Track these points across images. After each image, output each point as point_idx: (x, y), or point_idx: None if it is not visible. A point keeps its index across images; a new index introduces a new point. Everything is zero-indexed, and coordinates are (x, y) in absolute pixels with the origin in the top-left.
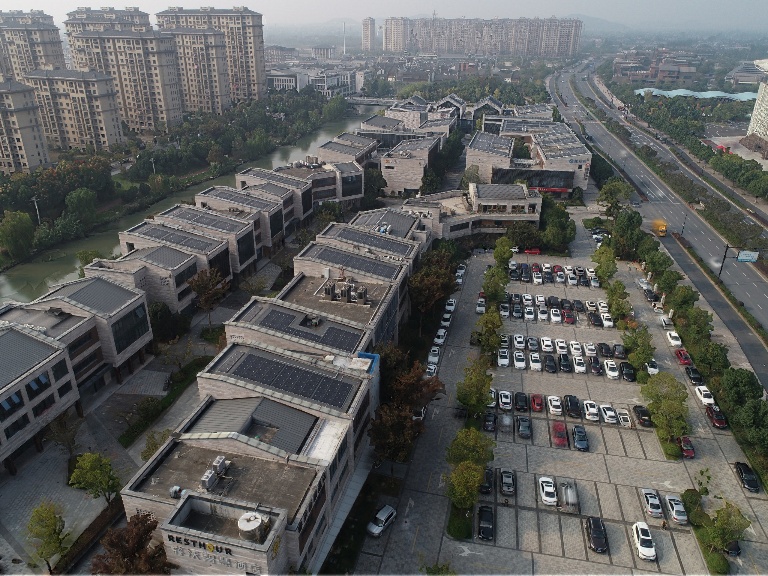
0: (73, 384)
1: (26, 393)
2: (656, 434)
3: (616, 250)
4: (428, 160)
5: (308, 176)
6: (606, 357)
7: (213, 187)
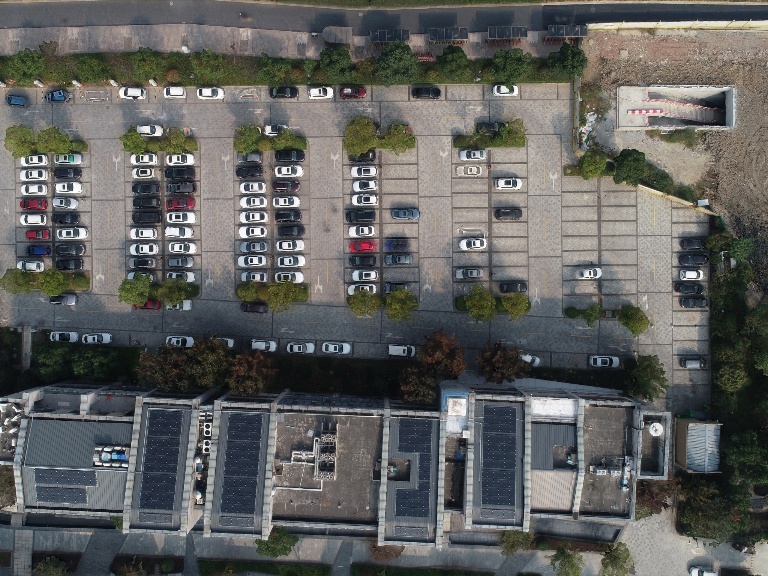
0: None
1: None
2: (384, 150)
3: None
4: None
5: None
6: (263, 173)
7: None
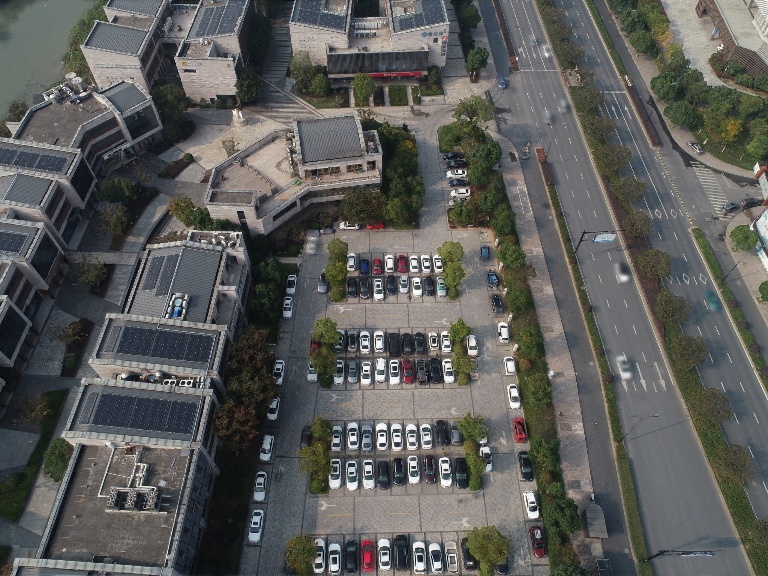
0: None
1: None
2: None
3: (468, 220)
4: (240, 44)
5: (74, 136)
6: (442, 446)
7: None
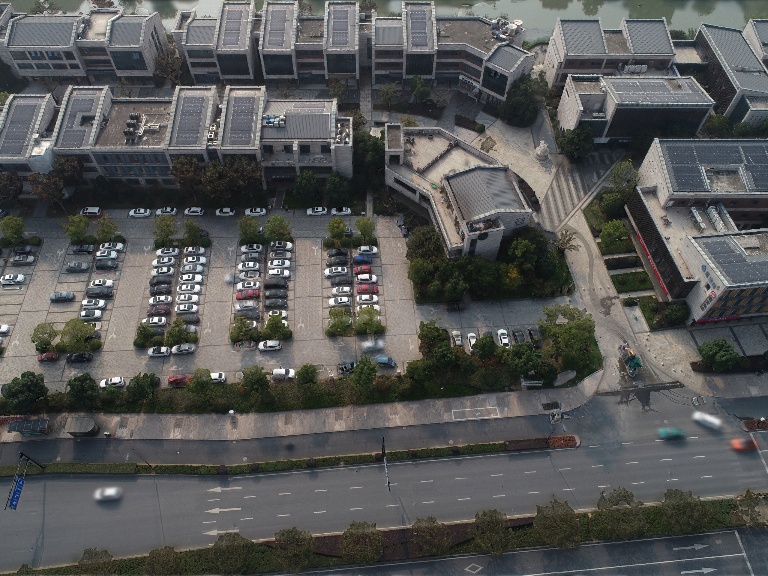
0: (80, 67)
1: (46, 55)
2: None
3: (421, 341)
4: (621, 118)
5: (452, 43)
6: None
7: (354, 2)
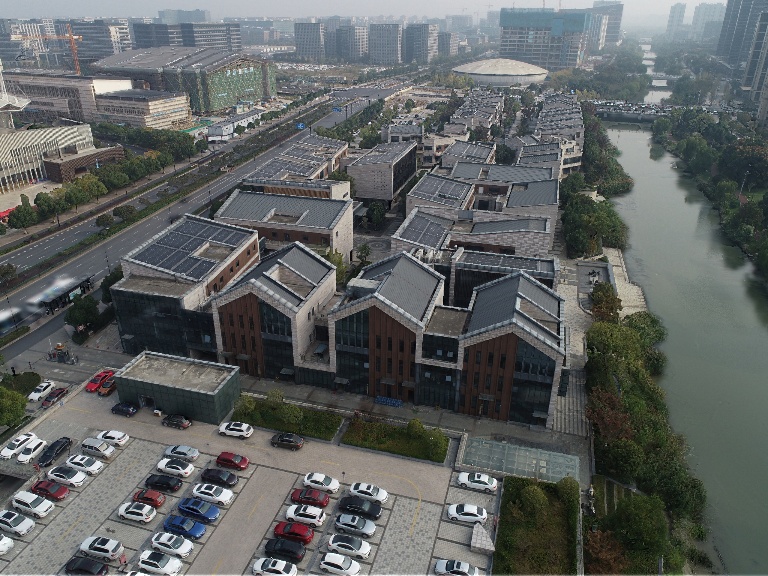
0: None
1: None
2: None
3: None
4: None
5: None
6: None
7: None
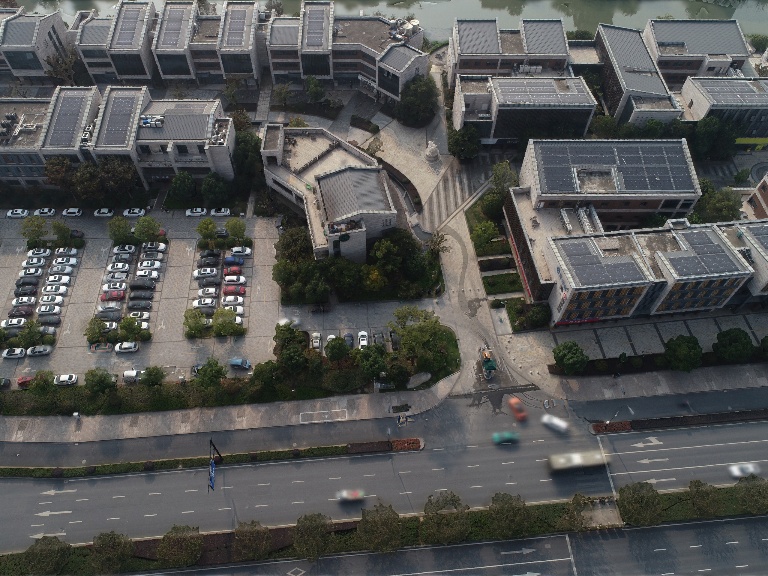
0: None
1: None
2: None
3: (276, 343)
4: (505, 118)
5: (347, 43)
6: None
7: (254, 2)
